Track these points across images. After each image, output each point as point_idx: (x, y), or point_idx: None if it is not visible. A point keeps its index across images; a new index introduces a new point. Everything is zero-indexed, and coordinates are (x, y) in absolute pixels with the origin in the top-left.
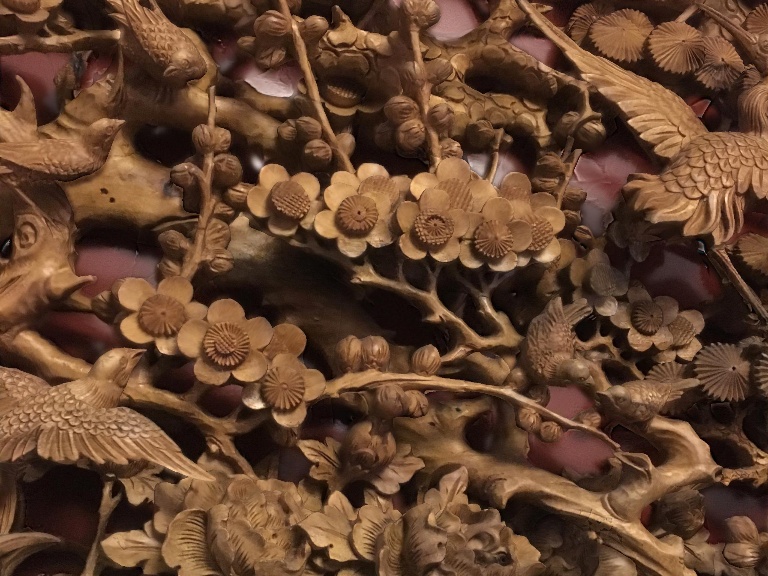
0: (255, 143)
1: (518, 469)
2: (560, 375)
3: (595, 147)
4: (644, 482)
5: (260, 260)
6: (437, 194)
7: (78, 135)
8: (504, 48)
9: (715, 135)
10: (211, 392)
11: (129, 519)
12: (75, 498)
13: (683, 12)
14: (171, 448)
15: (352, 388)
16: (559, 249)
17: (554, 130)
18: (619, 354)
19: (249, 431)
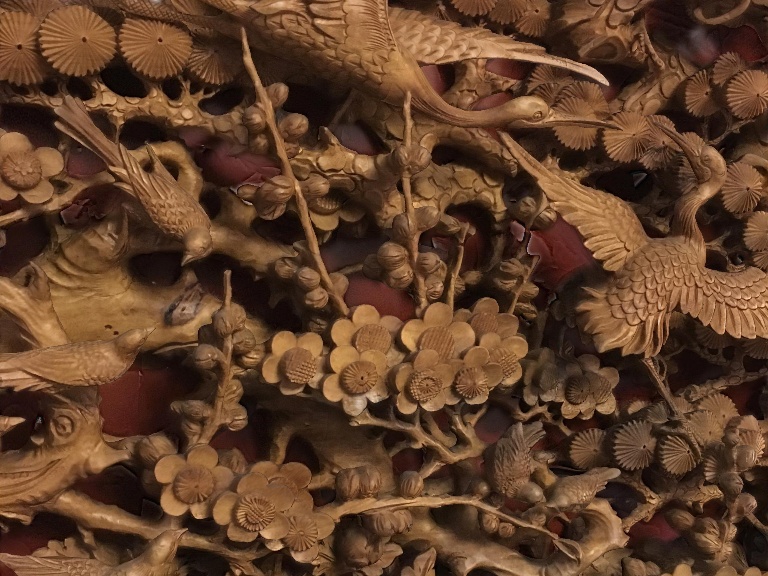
0: (248, 266)
1: (476, 548)
2: (520, 498)
3: (546, 229)
4: (574, 565)
5: (255, 374)
6: (428, 354)
7: (81, 281)
8: (471, 132)
9: (655, 252)
10: None
11: None
12: None
13: (634, 92)
14: None
15: (351, 514)
16: (521, 373)
17: (510, 207)
18: (551, 417)
19: (266, 555)
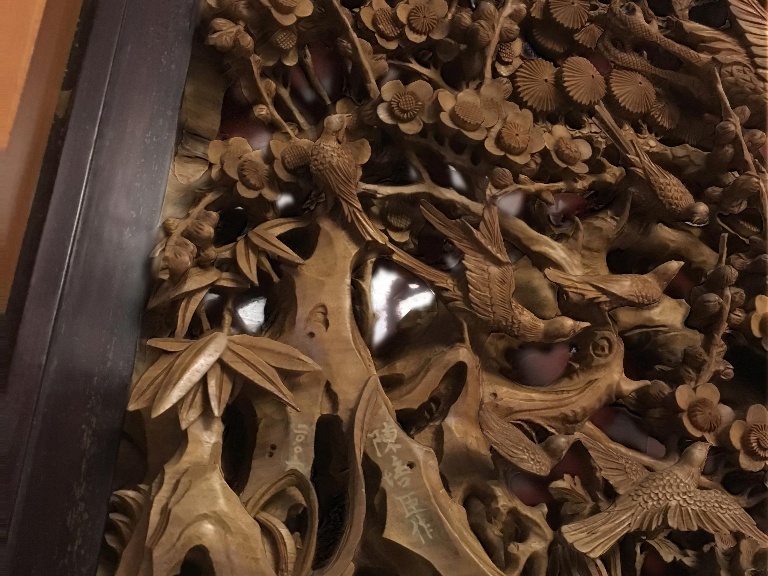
0: (698, 267)
1: None
2: None
3: None
4: None
5: None
6: None
7: (582, 258)
8: None
9: None
10: (731, 475)
11: (652, 573)
12: (621, 555)
13: None
14: (751, 522)
15: None
16: None
17: None
18: None
19: (753, 506)
